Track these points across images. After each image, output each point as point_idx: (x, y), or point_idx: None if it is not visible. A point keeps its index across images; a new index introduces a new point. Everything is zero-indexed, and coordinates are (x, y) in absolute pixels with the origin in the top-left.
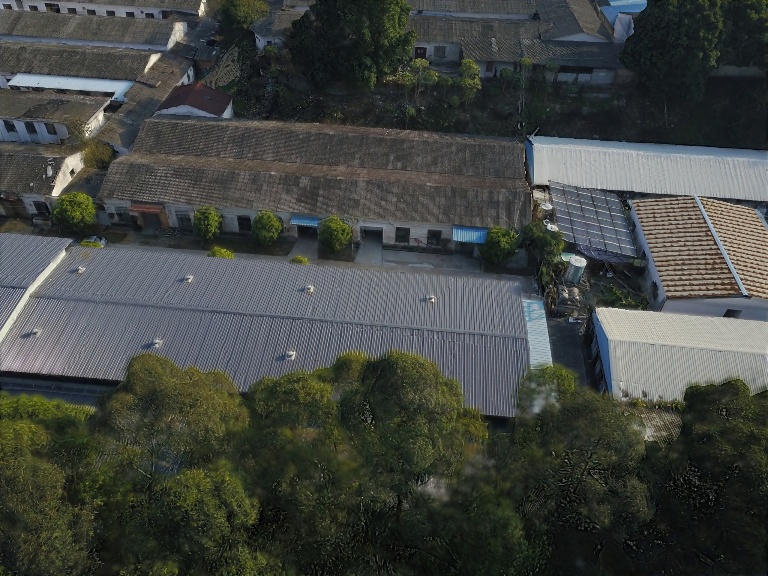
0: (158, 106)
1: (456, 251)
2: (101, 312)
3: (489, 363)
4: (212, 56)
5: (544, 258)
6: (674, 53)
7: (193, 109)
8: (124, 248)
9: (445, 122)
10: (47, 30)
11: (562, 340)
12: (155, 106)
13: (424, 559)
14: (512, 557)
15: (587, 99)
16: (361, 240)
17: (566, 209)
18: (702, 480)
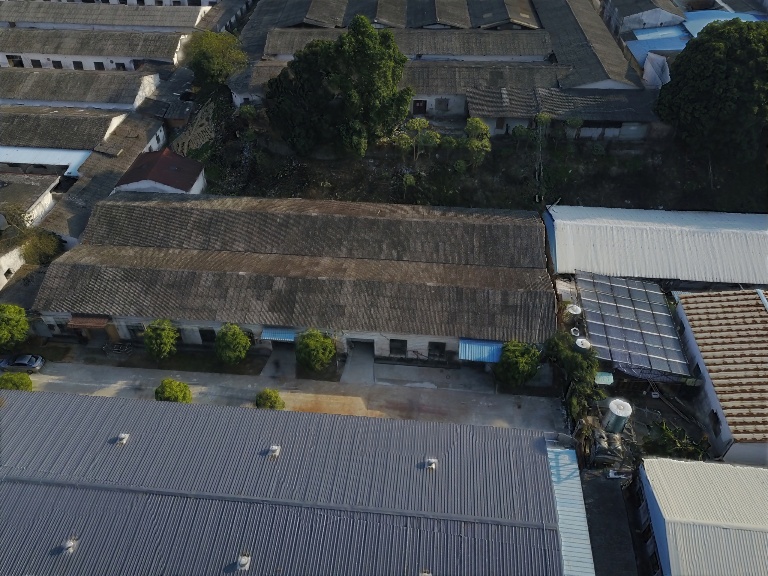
0: (118, 180)
1: (464, 364)
2: (5, 496)
3: (508, 572)
4: (185, 113)
5: (573, 379)
6: (722, 107)
7: (156, 184)
8: (65, 368)
9: (449, 190)
10: (1, 90)
11: (602, 505)
12: (114, 180)
13: None
14: None
15: (616, 157)
16: (349, 351)
17: (598, 311)
18: None
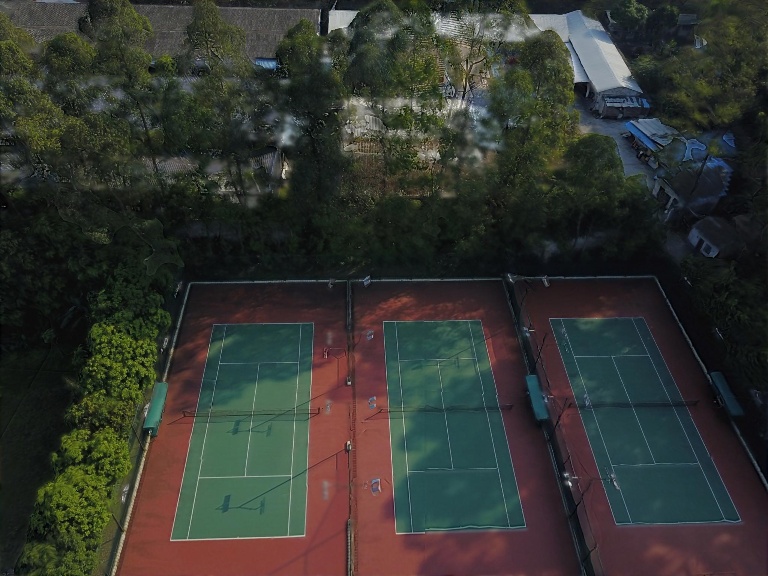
0: None
1: None
2: None
3: None
4: None
5: None
6: None
7: None
8: None
9: (269, 4)
10: None
11: None
12: None
13: (185, 193)
14: (179, 102)
15: None
16: None
17: None
18: (281, 64)
